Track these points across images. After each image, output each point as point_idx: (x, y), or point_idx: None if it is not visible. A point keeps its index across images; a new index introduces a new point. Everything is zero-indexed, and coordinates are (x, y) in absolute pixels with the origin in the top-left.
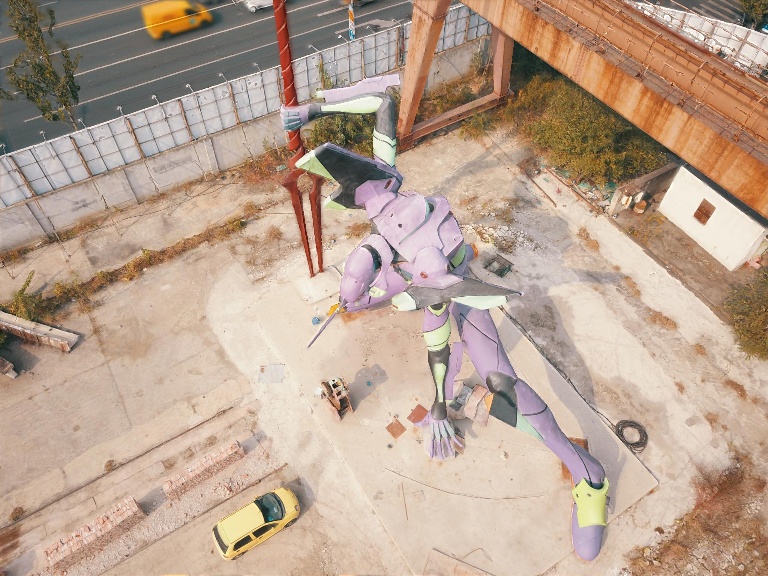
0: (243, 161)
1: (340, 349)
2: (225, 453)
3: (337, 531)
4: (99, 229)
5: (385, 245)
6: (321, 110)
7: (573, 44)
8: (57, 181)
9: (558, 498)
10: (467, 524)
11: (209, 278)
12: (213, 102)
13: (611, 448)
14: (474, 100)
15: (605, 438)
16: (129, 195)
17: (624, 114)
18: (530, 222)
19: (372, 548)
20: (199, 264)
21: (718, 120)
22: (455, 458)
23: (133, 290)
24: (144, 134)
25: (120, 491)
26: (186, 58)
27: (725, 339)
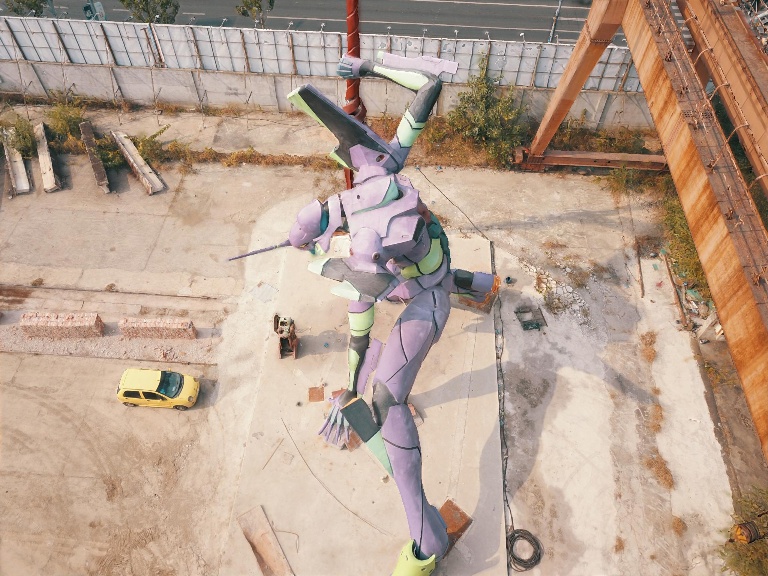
0: (382, 115)
1: (328, 304)
2: (176, 325)
3: (208, 439)
4: (238, 118)
5: (337, 208)
6: (373, 69)
7: (676, 108)
8: (222, 64)
9: (399, 548)
10: (304, 508)
11: (282, 194)
12: (370, 49)
13: (490, 545)
14: (636, 154)
15: (492, 532)
16: (273, 101)
17: (684, 206)
18: (600, 297)
19: (221, 470)
20: (284, 180)
21: (759, 253)
22: (341, 450)
23: (224, 174)
24: (302, 53)
25: (102, 308)
26: (407, 13)
27: (722, 536)
